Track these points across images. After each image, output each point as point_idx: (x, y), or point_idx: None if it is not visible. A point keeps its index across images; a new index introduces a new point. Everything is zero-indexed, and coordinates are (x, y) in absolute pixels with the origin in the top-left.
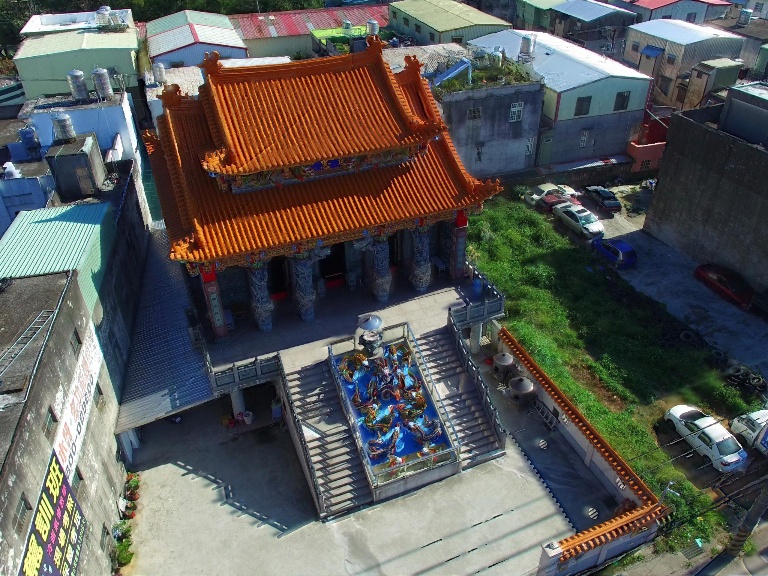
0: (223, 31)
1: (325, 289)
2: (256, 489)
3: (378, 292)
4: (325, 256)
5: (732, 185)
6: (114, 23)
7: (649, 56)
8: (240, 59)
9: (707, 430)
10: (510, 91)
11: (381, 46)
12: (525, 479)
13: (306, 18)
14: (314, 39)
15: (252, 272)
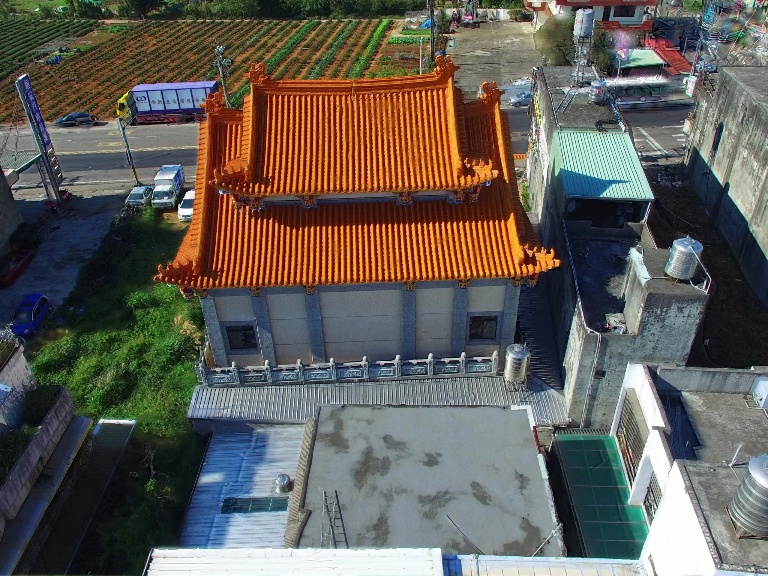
0: None
1: None
2: None
3: None
4: None
5: None
6: None
7: None
8: None
9: None
10: None
11: None
12: None
13: None
14: None
15: None
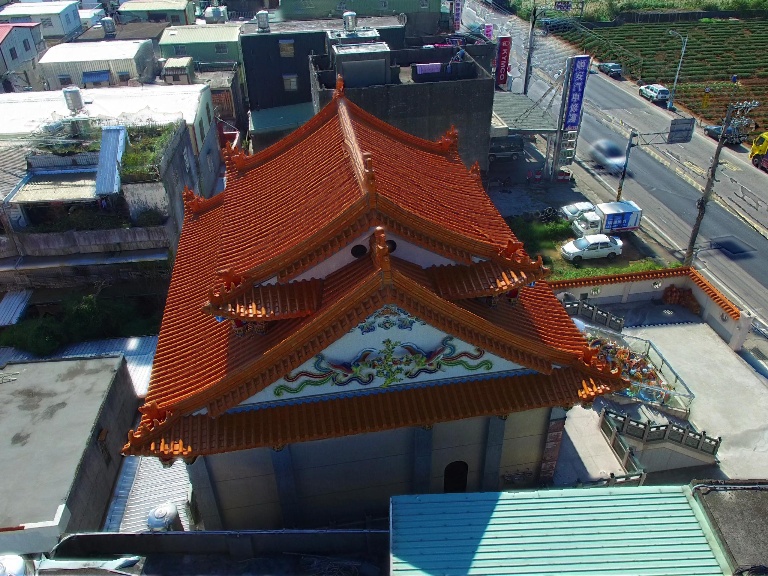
0: None
1: None
2: None
3: None
4: None
5: (400, 121)
6: None
7: (99, 82)
8: None
9: (600, 241)
10: (178, 139)
11: None
12: (644, 334)
13: None
14: None
15: None
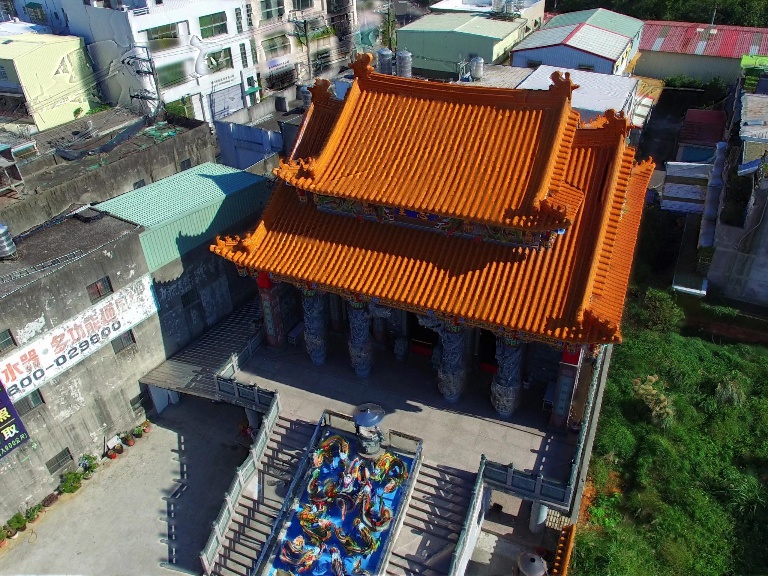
0: (612, 37)
1: (407, 352)
2: (197, 506)
3: (443, 386)
4: None
5: None
6: (506, 11)
7: None
8: (581, 71)
9: None
10: None
11: (571, 88)
12: None
13: (757, 39)
14: None
15: (304, 297)
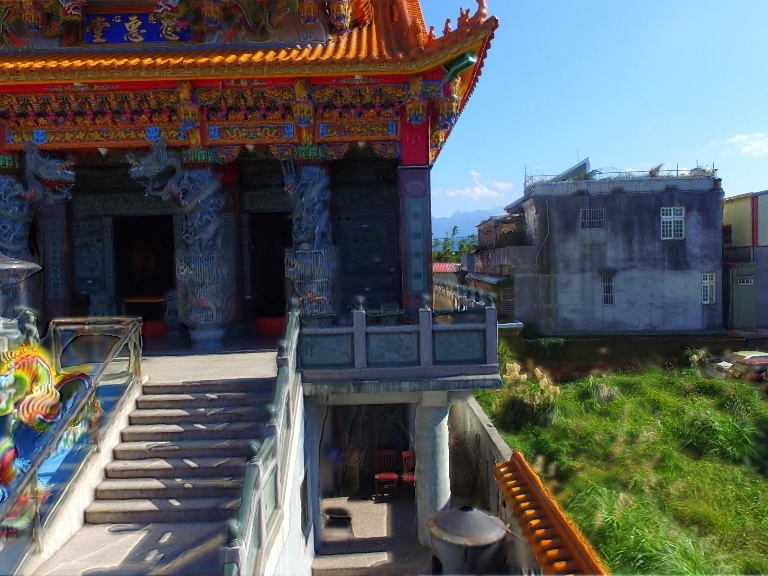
0: None
1: None
2: None
3: (189, 315)
4: (69, 194)
5: None
6: None
7: None
8: None
9: None
10: (655, 187)
11: None
12: None
13: None
14: (457, 270)
15: None
